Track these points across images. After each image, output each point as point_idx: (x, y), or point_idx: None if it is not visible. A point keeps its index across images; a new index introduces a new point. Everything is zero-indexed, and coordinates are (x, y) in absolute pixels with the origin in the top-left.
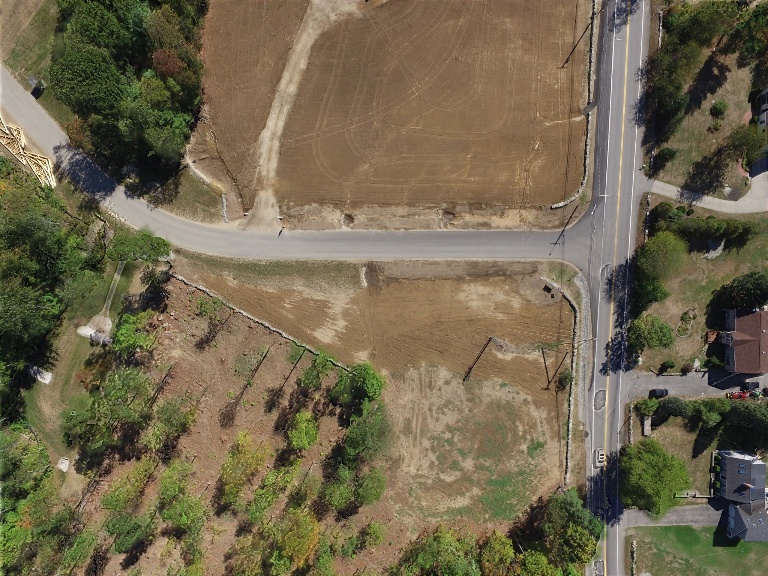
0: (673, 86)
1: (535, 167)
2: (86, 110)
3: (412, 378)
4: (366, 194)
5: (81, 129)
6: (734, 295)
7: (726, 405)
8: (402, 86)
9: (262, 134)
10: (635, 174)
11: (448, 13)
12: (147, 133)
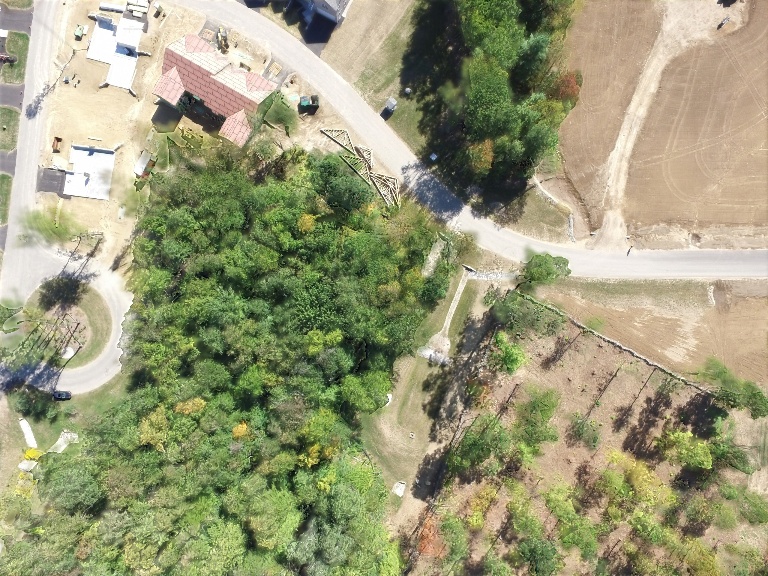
0: None
1: None
2: (496, 132)
3: None
4: (714, 214)
5: None
6: None
7: None
8: (751, 110)
9: (611, 155)
10: None
11: None
12: (530, 154)
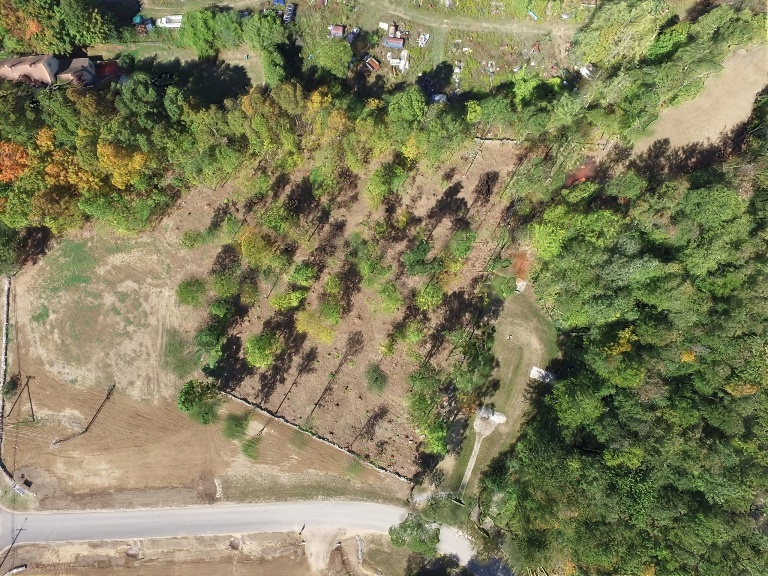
0: None
1: None
2: None
3: (167, 387)
4: (217, 572)
5: None
6: None
7: None
8: None
9: None
10: None
11: None
12: None
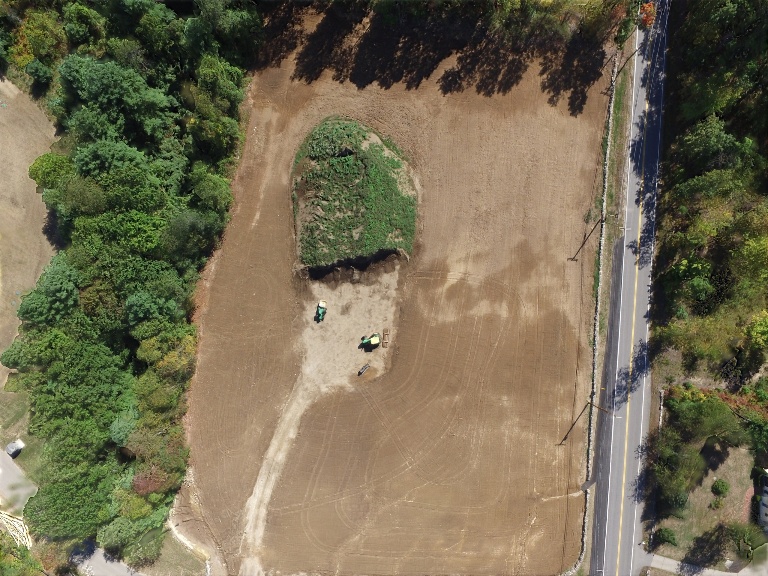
0: (674, 485)
1: (531, 541)
2: (62, 536)
3: None
4: (356, 565)
5: (56, 552)
6: None
7: None
8: (395, 459)
9: (248, 501)
10: (634, 548)
11: (443, 389)
12: None
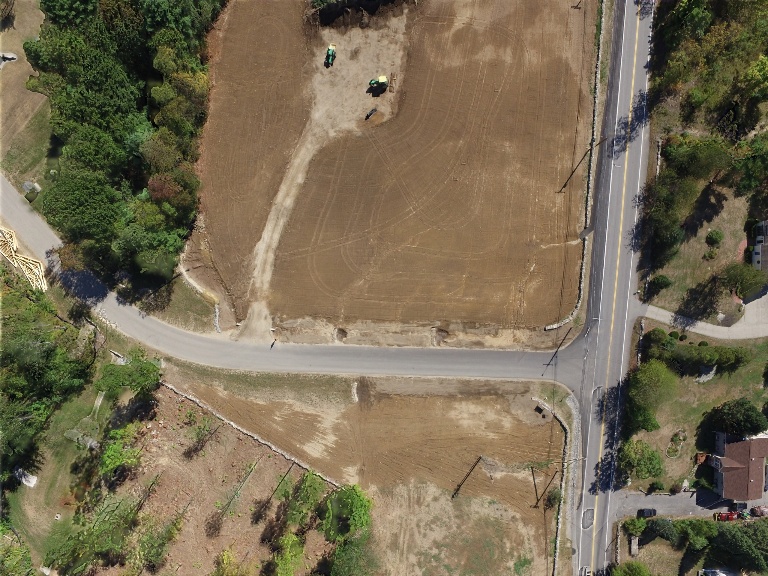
0: (670, 220)
1: (530, 289)
2: (79, 235)
3: (401, 494)
4: (360, 309)
5: (73, 253)
6: (724, 418)
7: (713, 530)
8: (399, 204)
9: (257, 246)
10: (629, 298)
11: (447, 134)
12: None
